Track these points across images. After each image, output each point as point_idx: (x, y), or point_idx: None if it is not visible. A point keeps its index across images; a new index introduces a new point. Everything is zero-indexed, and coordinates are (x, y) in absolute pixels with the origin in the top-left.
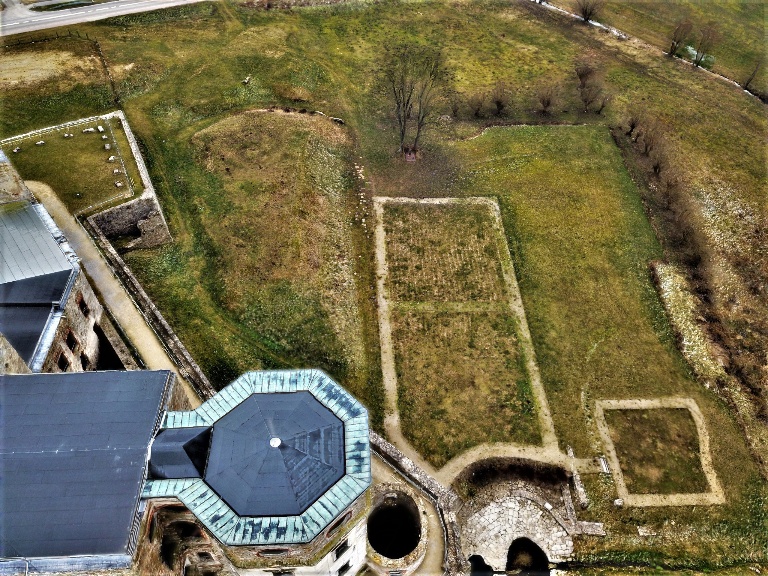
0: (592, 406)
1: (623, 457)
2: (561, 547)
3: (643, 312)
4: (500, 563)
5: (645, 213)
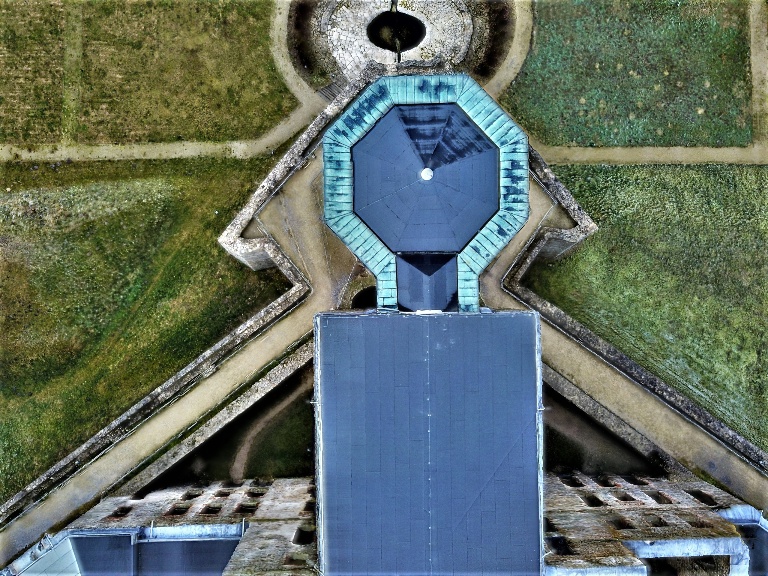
0: None
1: None
2: None
3: None
4: (390, 57)
5: None
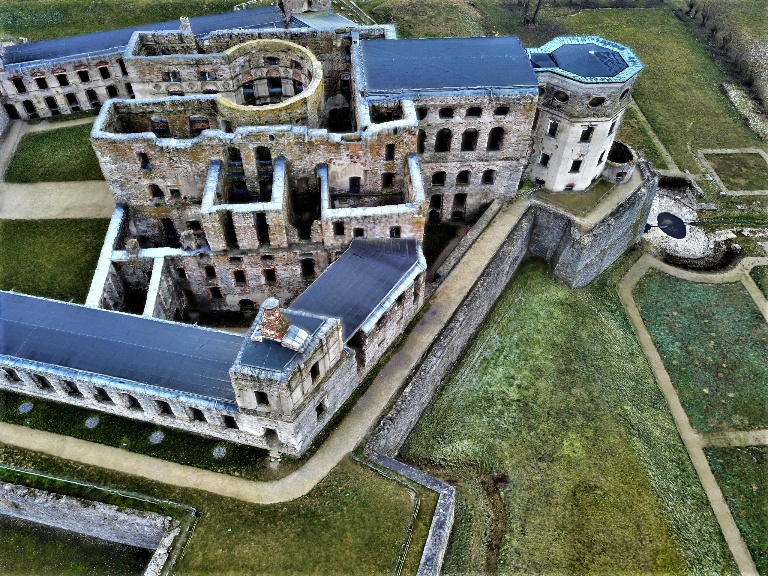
0: (696, 152)
1: (721, 174)
2: (690, 216)
3: (720, 107)
4: (654, 223)
5: (710, 57)
